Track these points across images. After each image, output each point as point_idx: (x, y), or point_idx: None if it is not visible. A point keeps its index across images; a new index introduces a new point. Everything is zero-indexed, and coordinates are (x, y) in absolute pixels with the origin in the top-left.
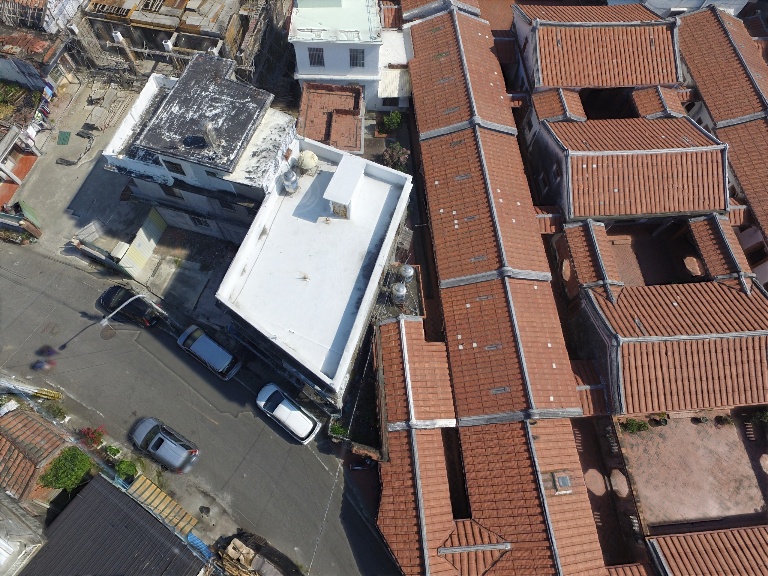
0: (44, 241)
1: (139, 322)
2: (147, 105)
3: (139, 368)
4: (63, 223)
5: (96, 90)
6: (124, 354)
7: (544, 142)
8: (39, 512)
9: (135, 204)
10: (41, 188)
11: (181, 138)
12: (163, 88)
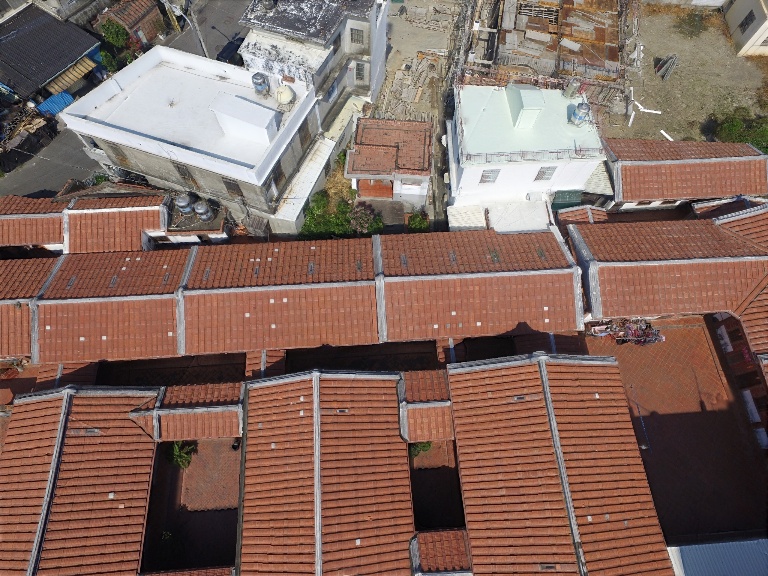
0: None
1: None
2: None
3: None
4: None
5: None
6: None
7: None
8: (96, 28)
9: None
10: None
11: None
12: None
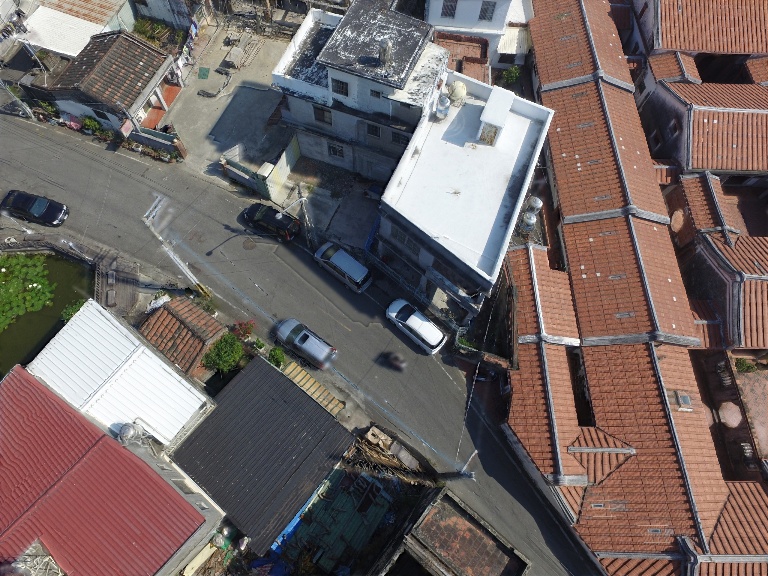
0: (189, 161)
1: (280, 235)
2: (304, 37)
3: (278, 277)
4: (206, 147)
5: (233, 32)
6: (264, 264)
7: (660, 101)
8: None
9: (270, 135)
10: (185, 115)
11: (355, 57)
12: (318, 23)
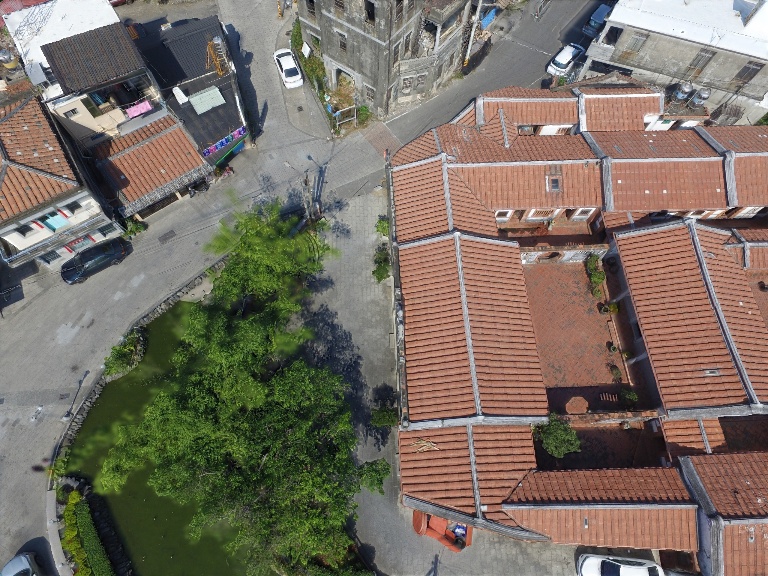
0: None
1: None
2: None
3: None
4: None
5: None
6: None
7: None
8: None
9: None
10: None
11: None
12: None
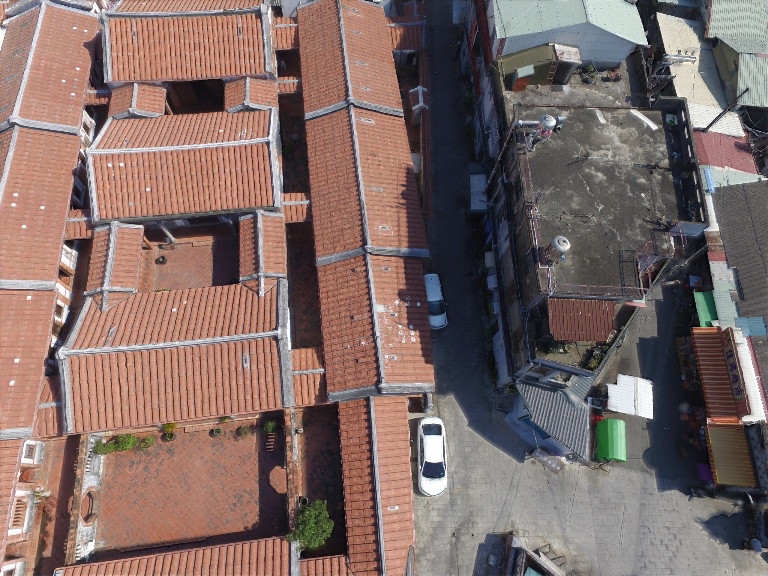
0: None
1: None
2: None
3: None
4: None
5: None
6: None
7: None
8: None
9: None
10: None
11: None
12: None
